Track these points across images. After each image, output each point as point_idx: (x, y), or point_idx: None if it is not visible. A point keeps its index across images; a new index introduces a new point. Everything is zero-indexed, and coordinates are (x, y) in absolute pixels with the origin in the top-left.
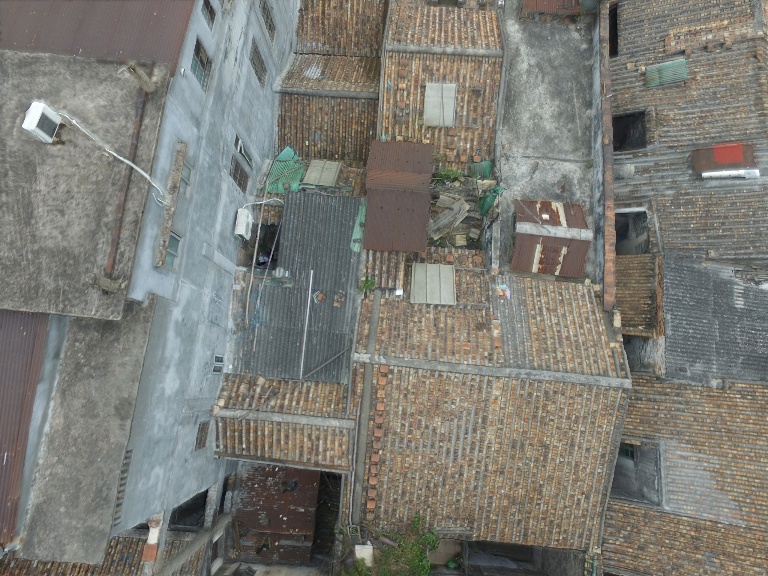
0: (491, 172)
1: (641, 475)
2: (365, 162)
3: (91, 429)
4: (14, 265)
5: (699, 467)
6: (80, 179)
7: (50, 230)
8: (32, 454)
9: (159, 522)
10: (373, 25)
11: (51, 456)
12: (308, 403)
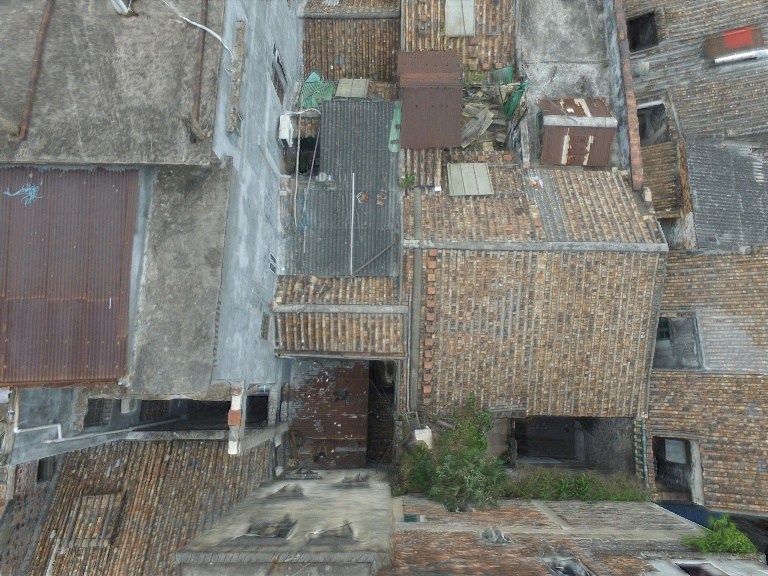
0: (513, 76)
1: (678, 349)
2: (389, 82)
3: (185, 278)
4: (104, 124)
5: (735, 328)
6: (157, 45)
7: (134, 91)
8: (133, 301)
9: (241, 390)
10: None
11: (150, 304)
12: (361, 295)
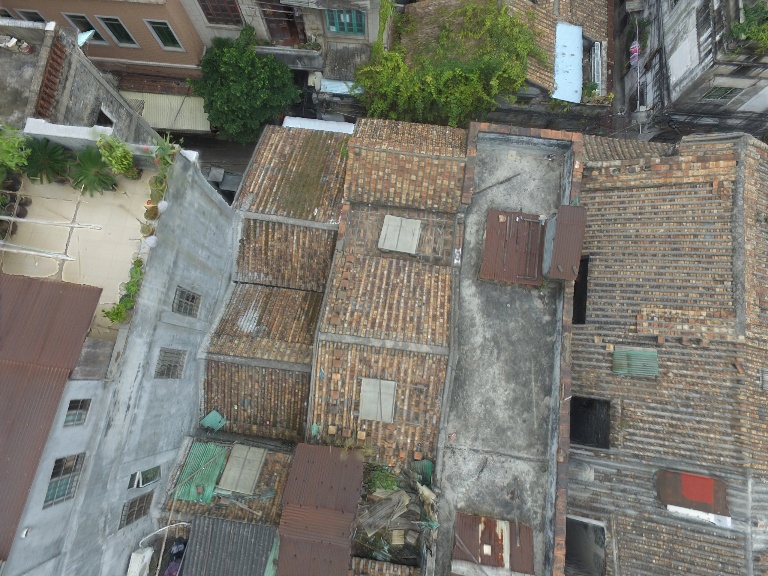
0: (432, 475)
1: None
2: (299, 431)
3: None
4: None
5: None
6: None
7: None
8: None
9: None
10: (320, 259)
11: None
12: None
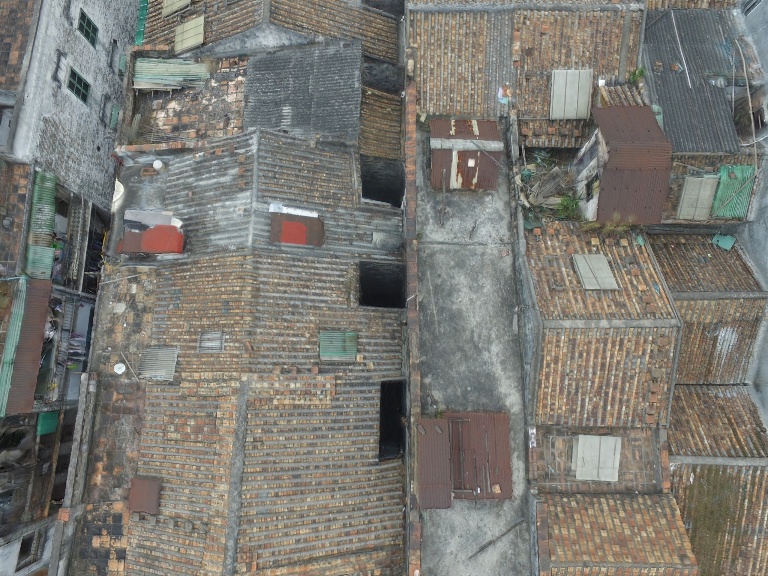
0: None
1: None
2: None
3: None
4: None
5: None
6: None
7: None
8: None
9: None
10: None
11: None
12: None
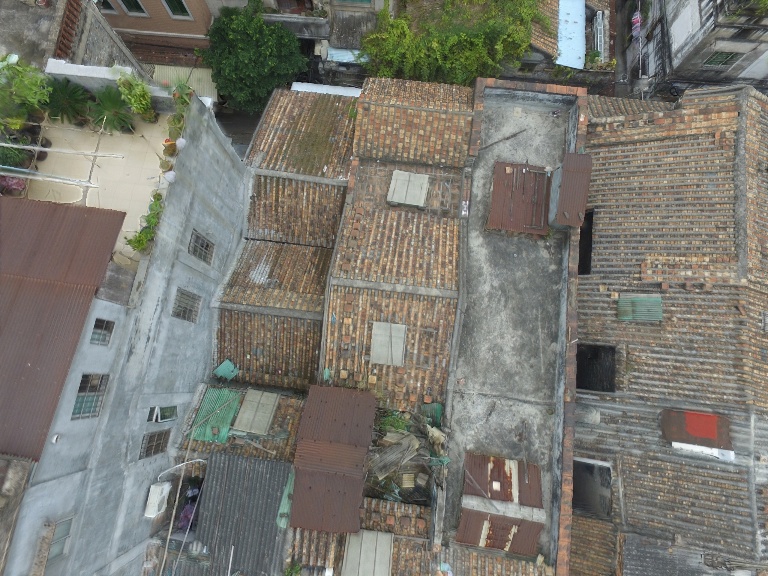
0: (442, 417)
1: None
2: (310, 380)
3: None
4: None
5: None
6: None
7: None
8: None
9: None
10: (330, 215)
11: None
12: None
